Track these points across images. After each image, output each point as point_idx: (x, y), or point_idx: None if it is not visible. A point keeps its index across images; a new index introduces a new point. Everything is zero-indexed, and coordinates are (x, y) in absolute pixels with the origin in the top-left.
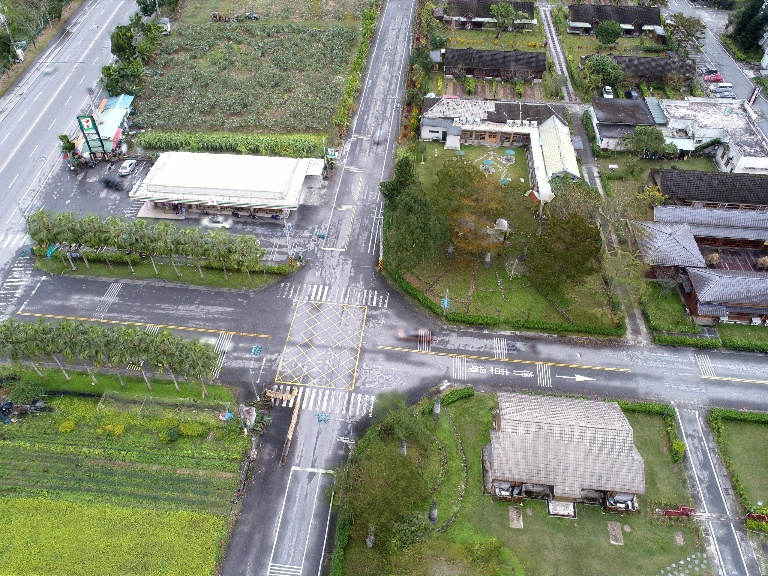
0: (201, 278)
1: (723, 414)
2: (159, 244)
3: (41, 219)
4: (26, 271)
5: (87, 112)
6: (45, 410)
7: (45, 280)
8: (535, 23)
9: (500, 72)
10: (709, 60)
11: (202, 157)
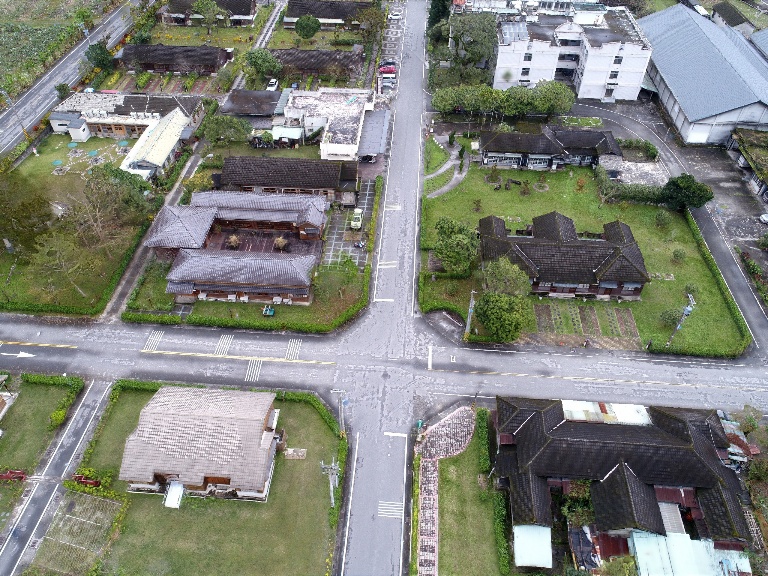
0: None
1: (125, 385)
2: None
3: None
4: None
5: None
6: None
7: None
8: (249, 19)
9: (177, 67)
10: (401, 52)
11: None
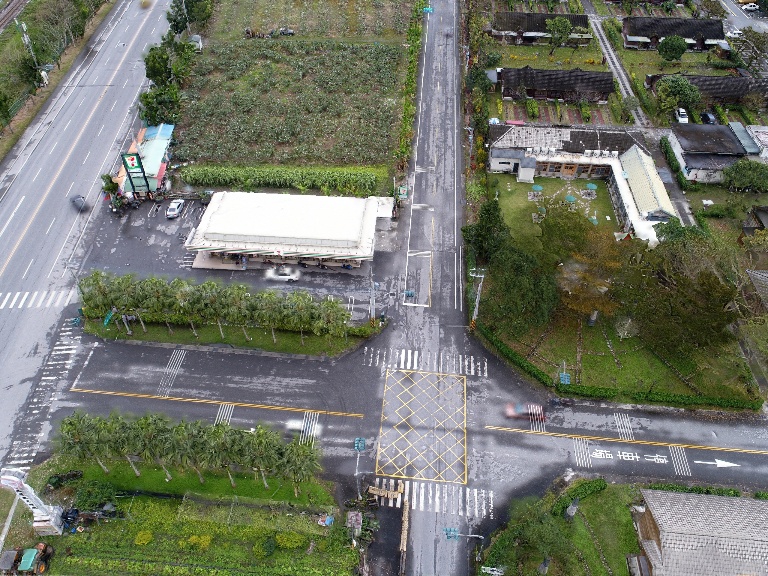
0: (273, 343)
1: None
2: (233, 311)
3: (97, 282)
4: (75, 336)
5: (123, 143)
6: (115, 515)
7: (98, 347)
8: (590, 38)
9: (563, 93)
10: None
11: (260, 198)
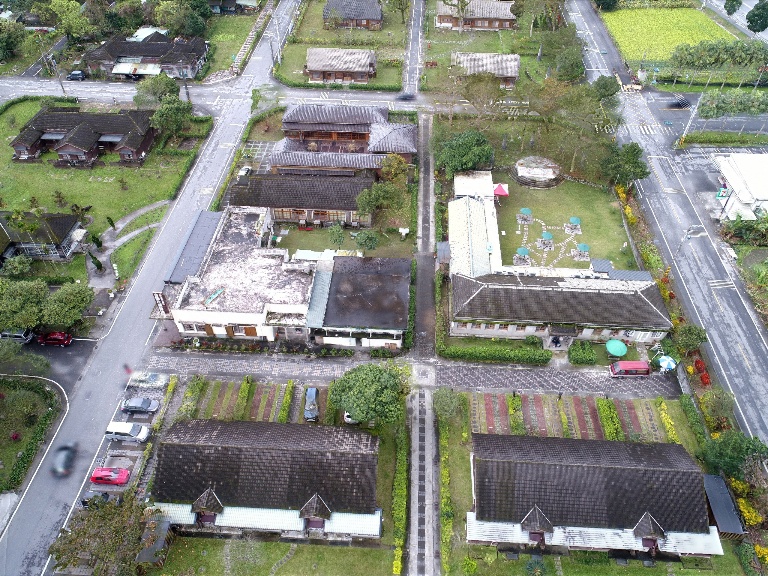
0: None
1: None
2: None
3: None
4: None
5: None
6: None
7: None
8: None
9: None
10: None
11: None
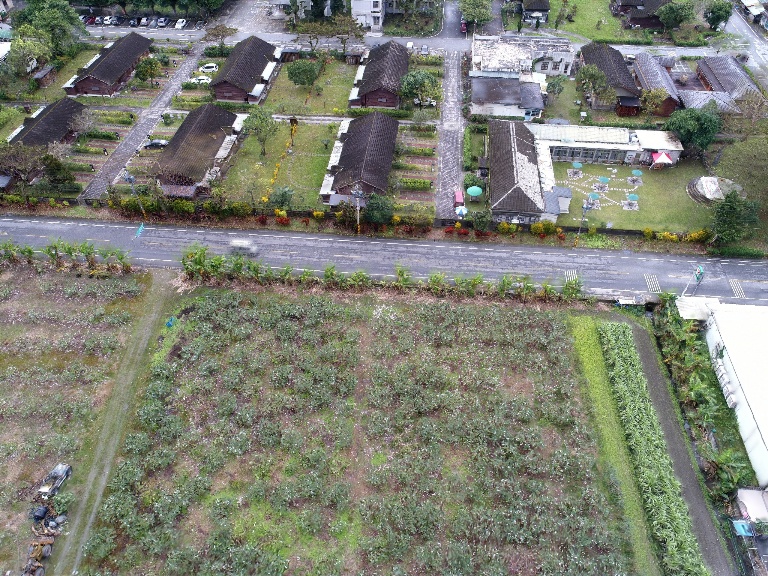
0: None
1: None
2: None
3: None
4: None
5: None
6: None
7: None
8: None
9: None
10: None
11: None
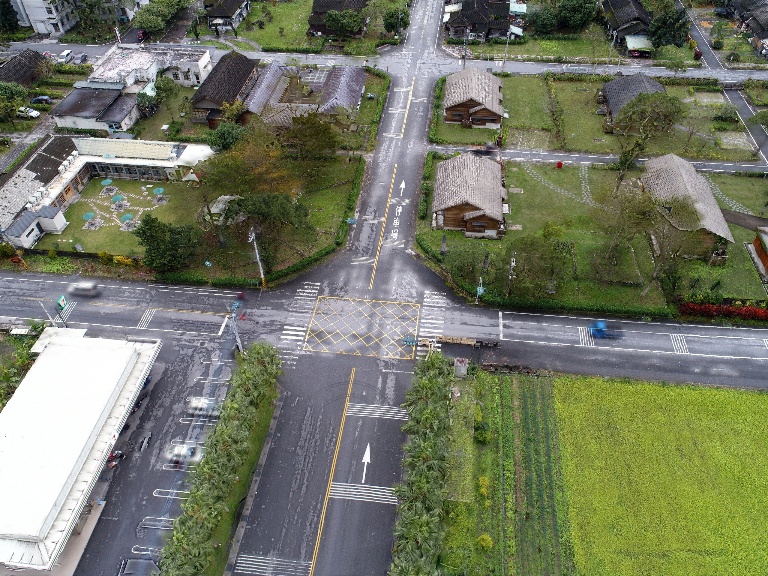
0: None
1: (433, 135)
2: None
3: None
4: None
5: None
6: None
7: None
8: None
9: None
10: (7, 53)
11: None
